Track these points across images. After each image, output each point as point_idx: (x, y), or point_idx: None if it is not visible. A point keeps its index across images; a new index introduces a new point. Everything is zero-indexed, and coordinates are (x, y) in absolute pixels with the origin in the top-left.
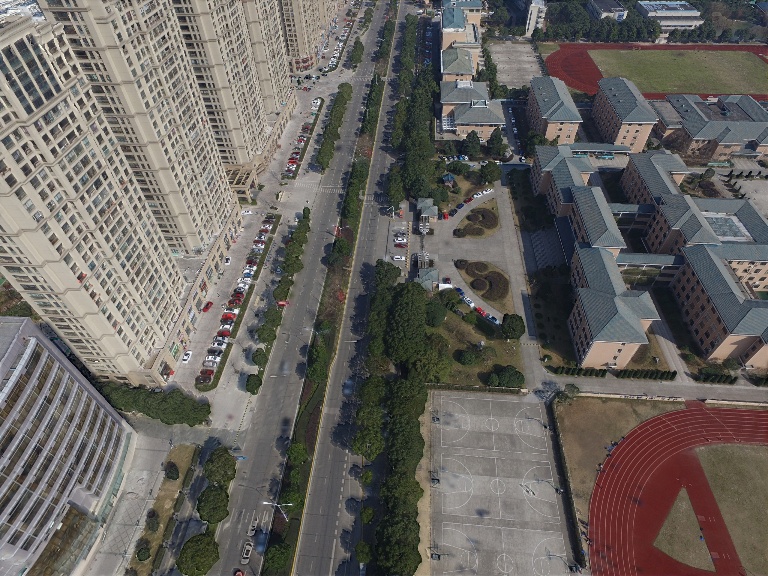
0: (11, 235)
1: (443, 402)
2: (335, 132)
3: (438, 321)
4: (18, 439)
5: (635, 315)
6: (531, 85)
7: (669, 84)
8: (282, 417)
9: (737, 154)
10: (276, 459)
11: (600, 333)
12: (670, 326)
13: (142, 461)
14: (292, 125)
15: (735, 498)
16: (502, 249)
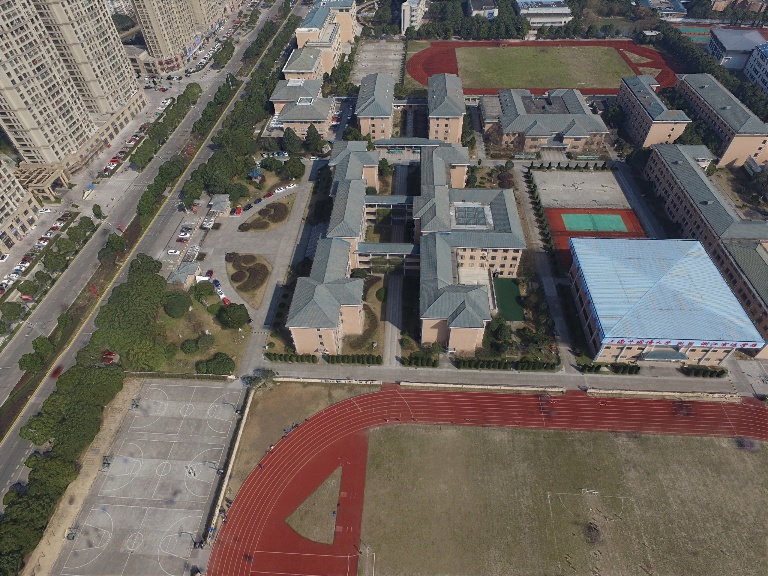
0: None
1: (150, 390)
2: (160, 131)
3: (175, 312)
4: None
5: (336, 301)
6: (361, 82)
7: (518, 79)
8: None
9: (545, 146)
10: None
11: (292, 319)
12: (403, 313)
13: None
14: (132, 125)
15: (384, 475)
16: (278, 242)
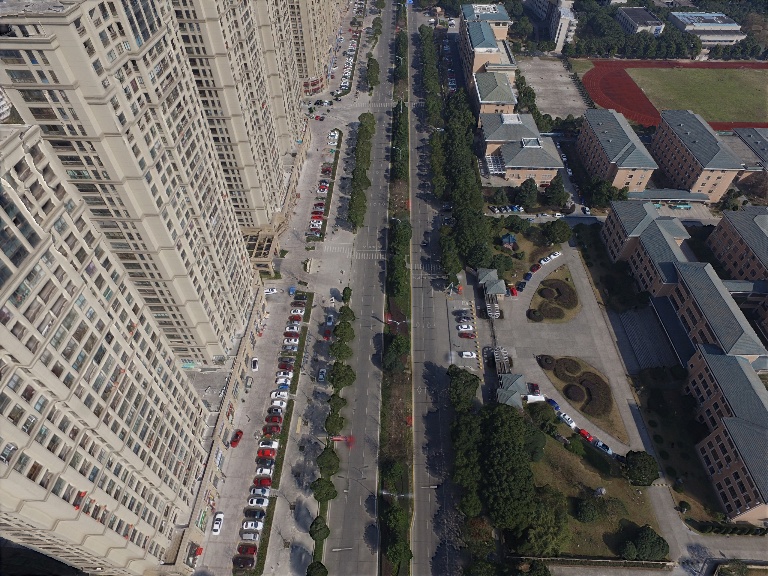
0: None
1: None
2: (366, 179)
3: (540, 457)
4: None
5: None
6: (587, 119)
7: (724, 111)
8: None
9: None
10: None
11: None
12: None
13: None
14: (309, 166)
15: None
16: (590, 338)
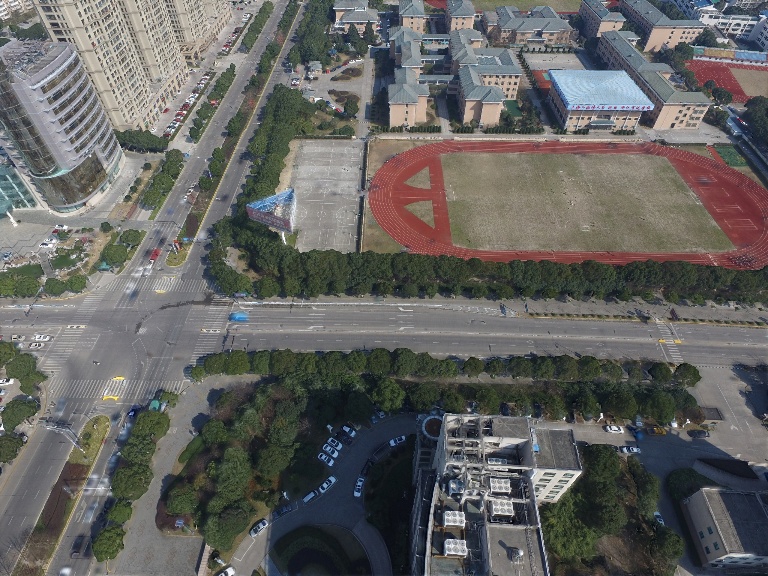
0: (60, 5)
1: (307, 143)
2: (257, 27)
3: (309, 111)
4: (72, 91)
5: (415, 93)
6: None
7: None
8: (212, 151)
9: (530, 40)
10: (207, 164)
11: (392, 98)
12: (449, 113)
13: (129, 166)
14: (227, 28)
15: (452, 168)
16: (360, 86)
